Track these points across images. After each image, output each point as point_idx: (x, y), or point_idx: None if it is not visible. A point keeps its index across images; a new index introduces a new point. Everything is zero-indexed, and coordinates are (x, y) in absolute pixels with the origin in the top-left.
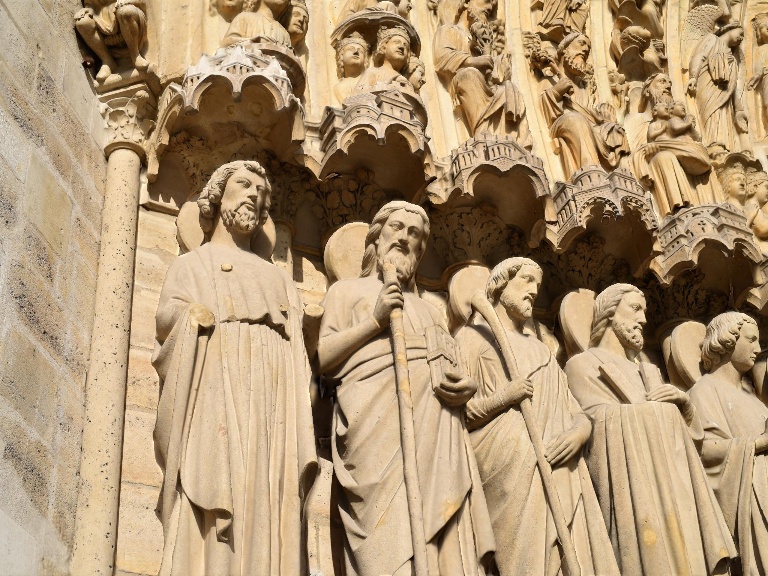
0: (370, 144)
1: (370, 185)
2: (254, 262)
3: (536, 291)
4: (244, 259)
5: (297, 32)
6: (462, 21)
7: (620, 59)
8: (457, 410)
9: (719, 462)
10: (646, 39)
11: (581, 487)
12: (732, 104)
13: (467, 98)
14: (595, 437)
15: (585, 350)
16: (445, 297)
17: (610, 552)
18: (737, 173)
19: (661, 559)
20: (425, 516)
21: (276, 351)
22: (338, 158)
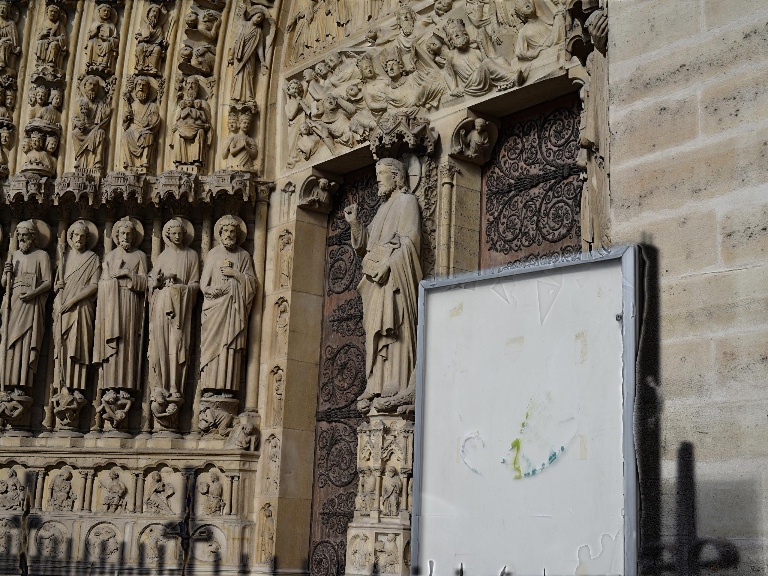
0: None
1: None
2: None
3: (79, 239)
4: None
5: (5, 144)
6: None
7: (179, 69)
8: (30, 301)
9: None
10: (188, 56)
11: None
12: None
13: None
14: None
15: None
16: None
17: (74, 341)
18: (230, 119)
19: (97, 339)
20: (9, 341)
21: None
22: None
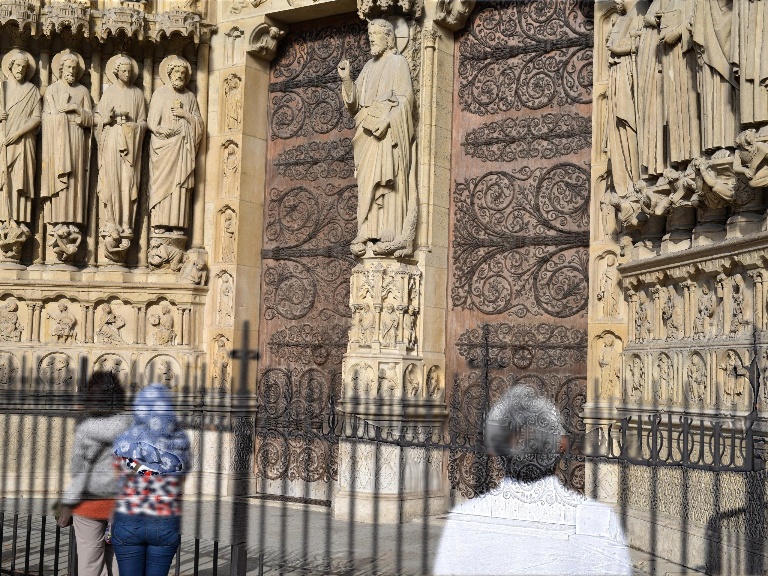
0: None
1: None
2: None
3: (21, 70)
4: None
5: None
6: None
7: None
8: None
9: None
10: None
11: None
12: None
13: None
14: None
15: None
16: None
17: (21, 174)
18: None
19: (45, 173)
20: None
21: None
22: None
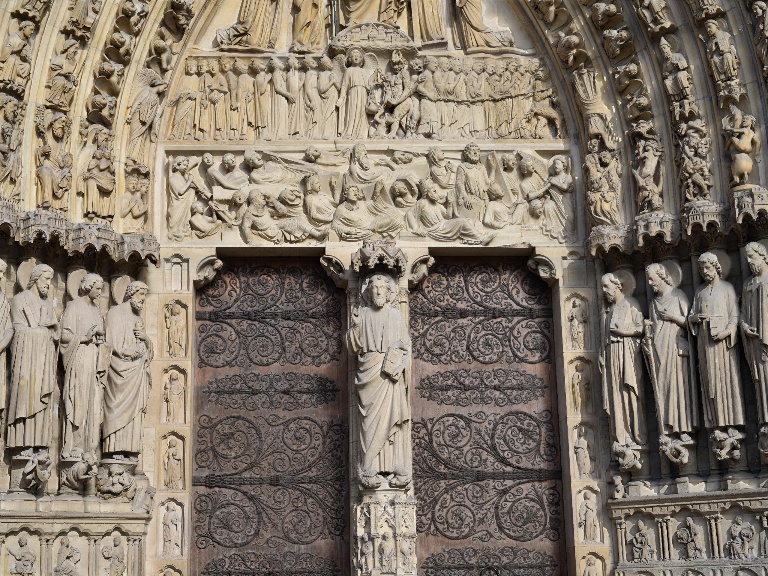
0: None
1: None
2: None
3: None
4: None
5: None
6: (1, 113)
7: (88, 114)
8: None
9: (67, 343)
10: (104, 105)
11: (0, 364)
12: None
13: None
14: (15, 337)
15: (24, 290)
16: None
17: (3, 392)
18: (133, 180)
19: (24, 391)
20: None
21: None
22: None
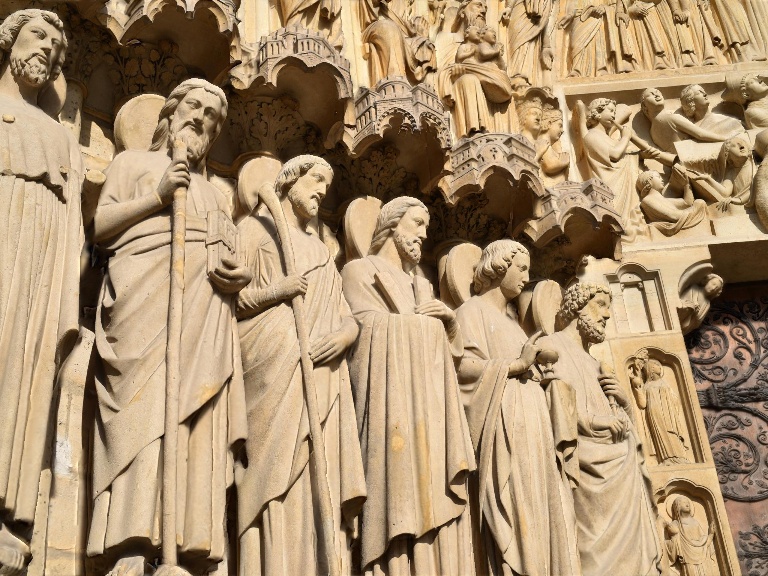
0: (178, 16)
1: (172, 58)
2: (39, 117)
3: (324, 191)
4: (29, 113)
5: None
6: None
7: None
8: (229, 297)
9: (474, 380)
10: None
11: (339, 388)
12: (541, 39)
13: None
14: (360, 342)
15: (364, 256)
16: (233, 184)
17: (358, 452)
18: (535, 107)
19: (405, 465)
20: (181, 397)
21: (50, 212)
22: (143, 24)
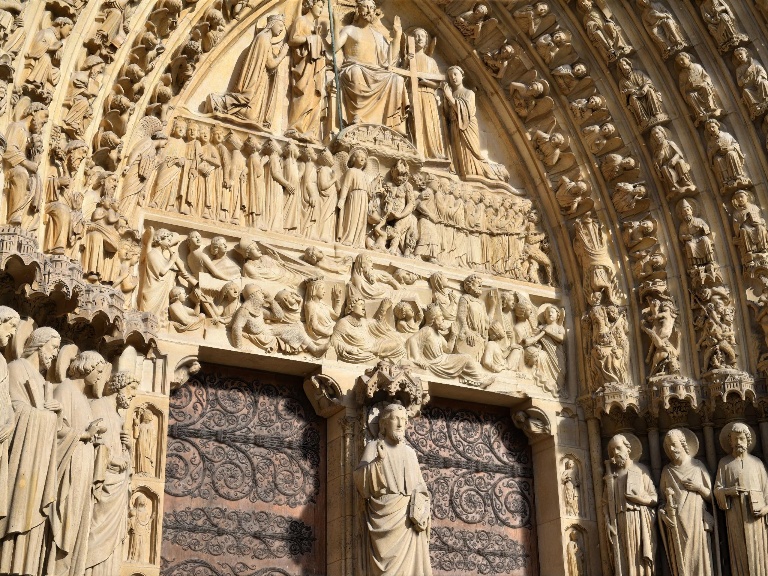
0: None
1: None
2: None
3: None
4: None
5: None
6: (27, 122)
7: (97, 152)
8: None
9: (60, 438)
10: (116, 145)
11: (2, 453)
12: None
13: (16, 190)
14: None
15: (19, 358)
16: None
17: None
18: (127, 245)
19: (24, 495)
20: None
21: None
22: None
